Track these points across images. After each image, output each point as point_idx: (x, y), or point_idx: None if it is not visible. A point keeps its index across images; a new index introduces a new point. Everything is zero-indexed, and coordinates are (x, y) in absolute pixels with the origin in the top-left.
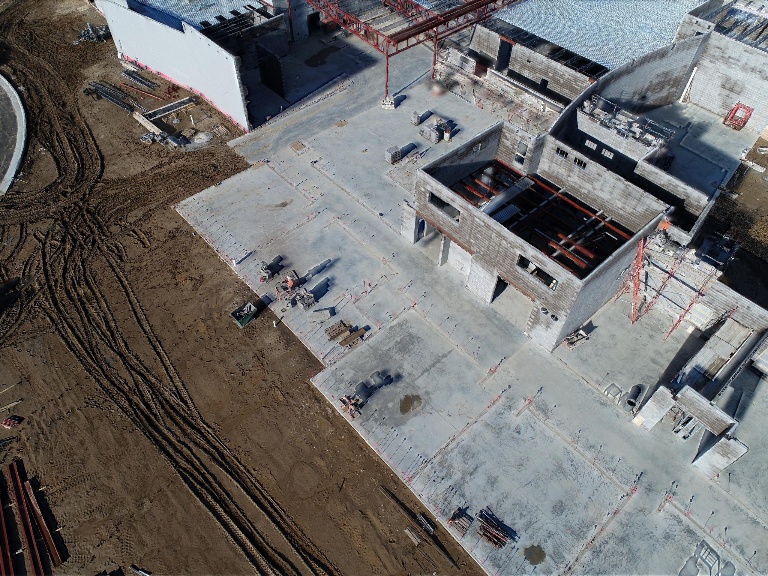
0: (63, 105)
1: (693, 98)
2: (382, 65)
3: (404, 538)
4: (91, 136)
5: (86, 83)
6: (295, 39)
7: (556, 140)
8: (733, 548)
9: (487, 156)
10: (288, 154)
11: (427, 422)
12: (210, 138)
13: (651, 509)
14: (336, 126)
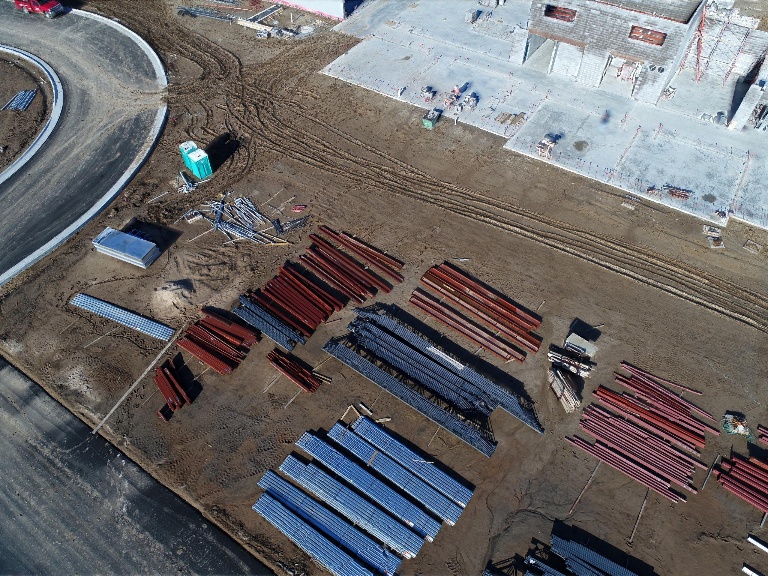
0: (166, 25)
1: None
2: None
3: (623, 208)
4: (210, 41)
5: (174, 8)
6: None
7: None
8: None
9: None
10: (386, 29)
11: (599, 152)
12: (314, 28)
13: (764, 165)
14: (411, 8)
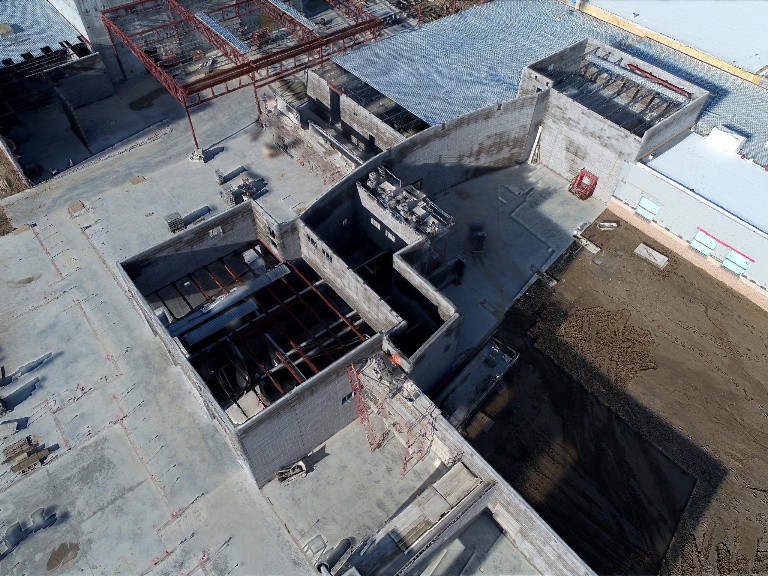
0: None
1: (543, 159)
2: (213, 110)
3: None
4: None
5: None
6: (129, 77)
7: (304, 226)
8: None
9: (241, 238)
10: (61, 216)
11: None
12: None
13: None
14: (130, 183)
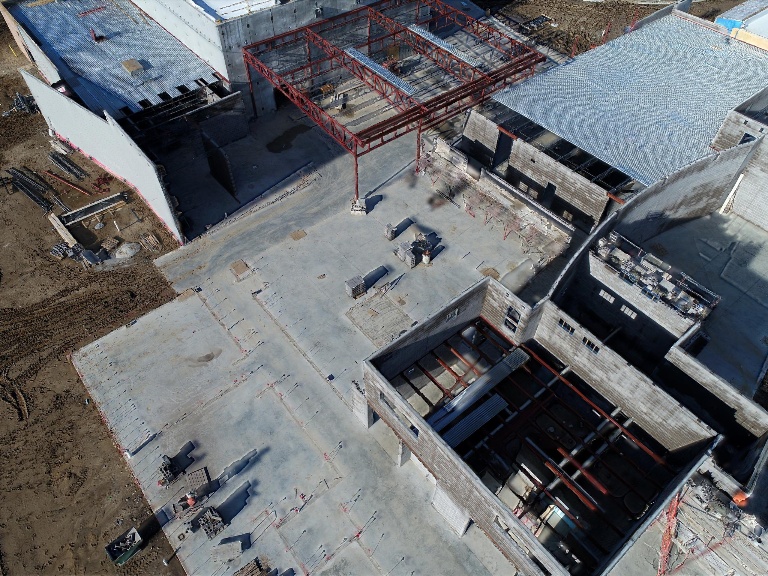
0: None
1: (737, 209)
2: (358, 152)
3: None
4: None
5: (4, 169)
6: (259, 114)
7: (559, 310)
8: None
9: (468, 317)
10: (226, 279)
11: None
12: (135, 252)
13: None
14: (291, 238)
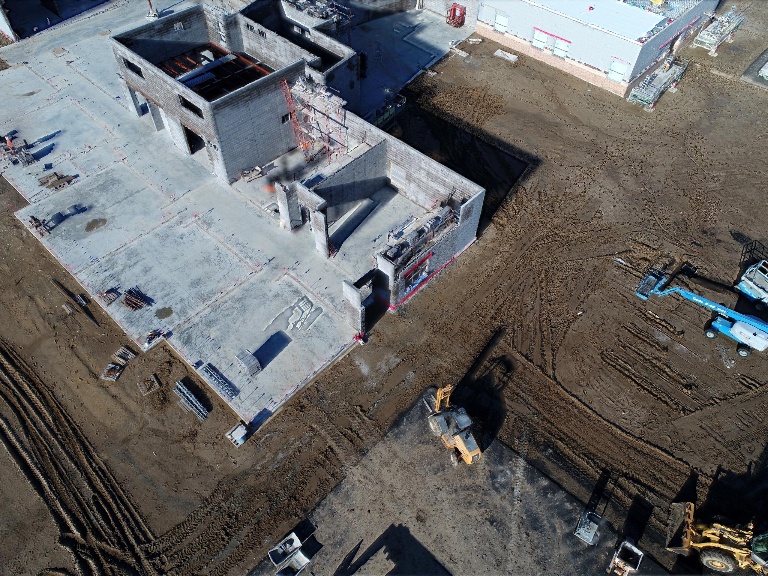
0: None
1: (427, 4)
2: None
3: (60, 311)
4: None
5: None
6: None
7: (244, 16)
8: (326, 299)
9: (197, 38)
10: (48, 57)
11: (106, 235)
12: None
13: (271, 279)
14: (100, 35)
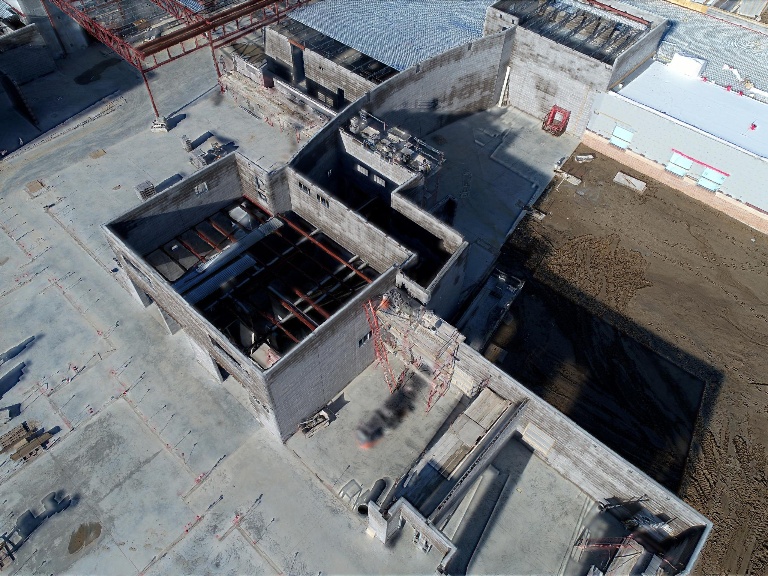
0: None
1: (513, 101)
2: (166, 78)
3: None
4: None
5: None
6: (69, 51)
7: (295, 174)
8: None
9: (226, 194)
10: (19, 198)
11: (100, 562)
12: None
13: None
14: (90, 158)
